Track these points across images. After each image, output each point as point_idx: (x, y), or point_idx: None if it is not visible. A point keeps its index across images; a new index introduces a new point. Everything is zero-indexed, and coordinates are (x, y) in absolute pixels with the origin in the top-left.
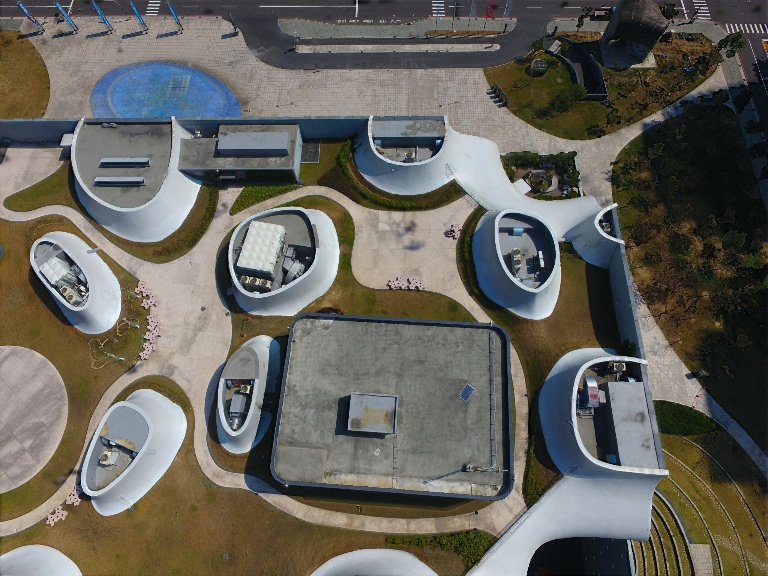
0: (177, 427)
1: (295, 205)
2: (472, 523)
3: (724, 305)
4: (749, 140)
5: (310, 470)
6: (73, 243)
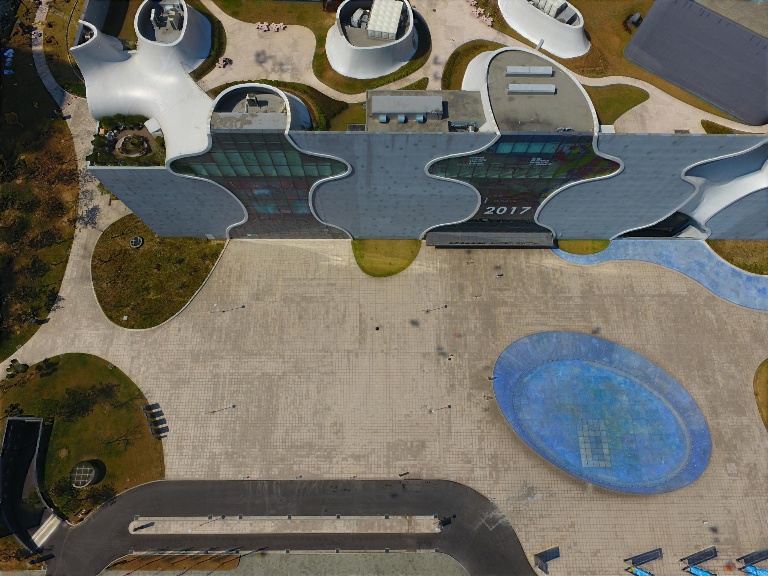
0: None
1: (368, 85)
2: None
3: (8, 174)
4: None
5: None
6: (558, 44)
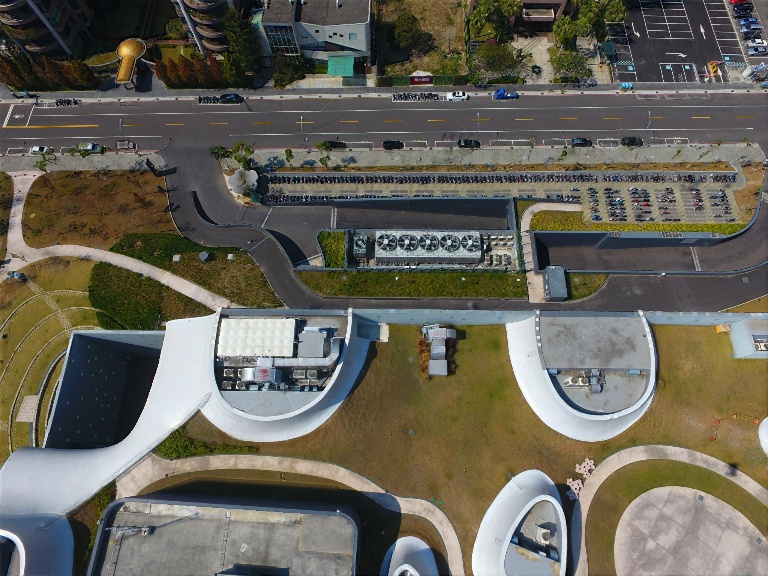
0: (482, 569)
1: None
2: (173, 466)
3: None
4: None
5: (316, 527)
6: None
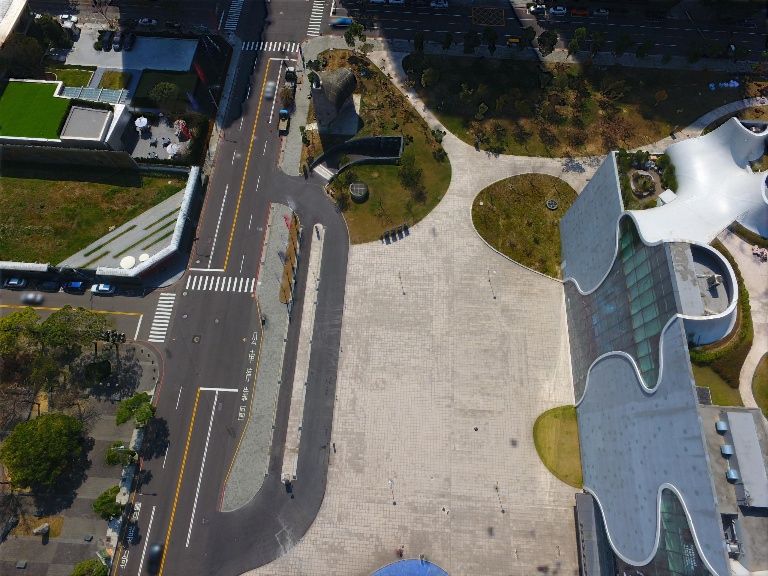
0: None
1: None
2: None
3: None
4: (442, 52)
5: None
6: None
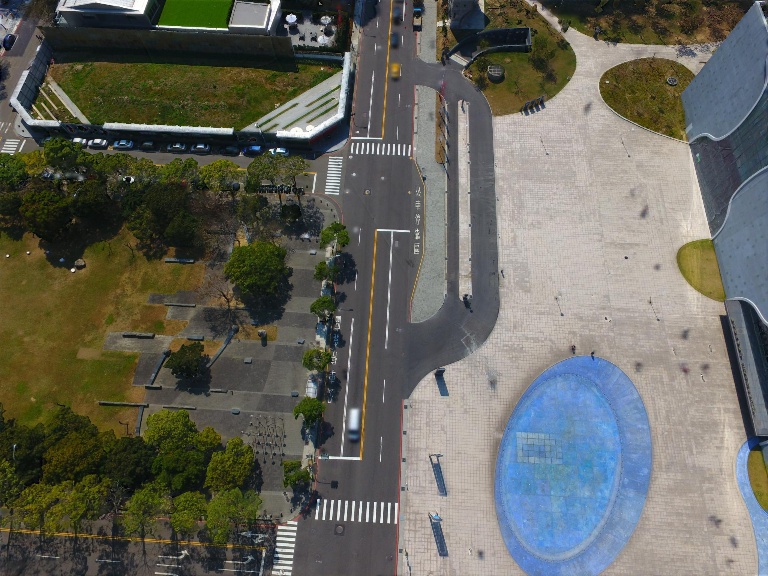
0: None
1: None
2: None
3: None
4: None
5: None
6: None
